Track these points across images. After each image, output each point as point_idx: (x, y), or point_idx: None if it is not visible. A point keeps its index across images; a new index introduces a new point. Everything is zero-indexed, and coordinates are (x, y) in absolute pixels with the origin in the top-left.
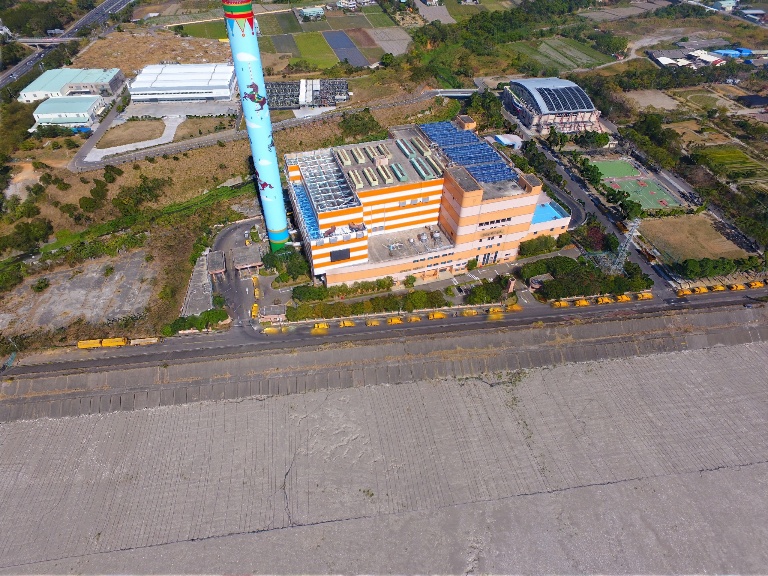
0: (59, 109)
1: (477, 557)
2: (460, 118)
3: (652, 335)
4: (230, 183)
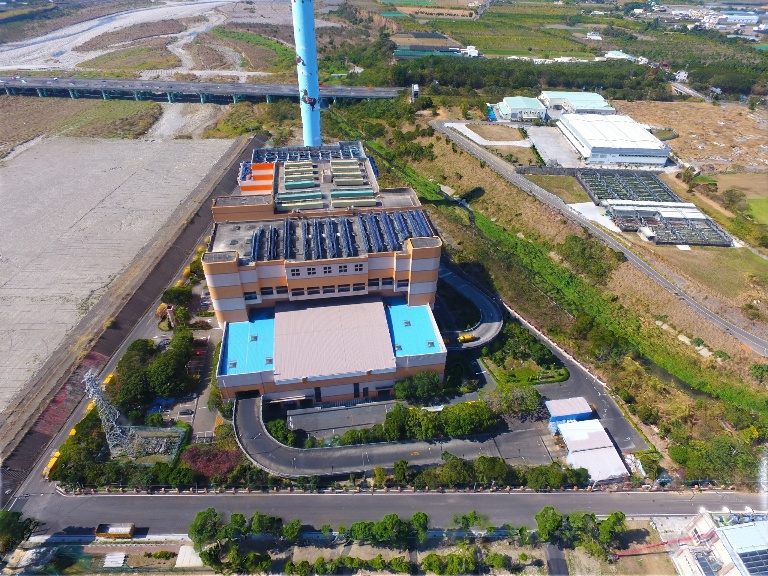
0: (514, 102)
1: (2, 260)
2: (431, 238)
3: (1, 434)
4: (445, 189)
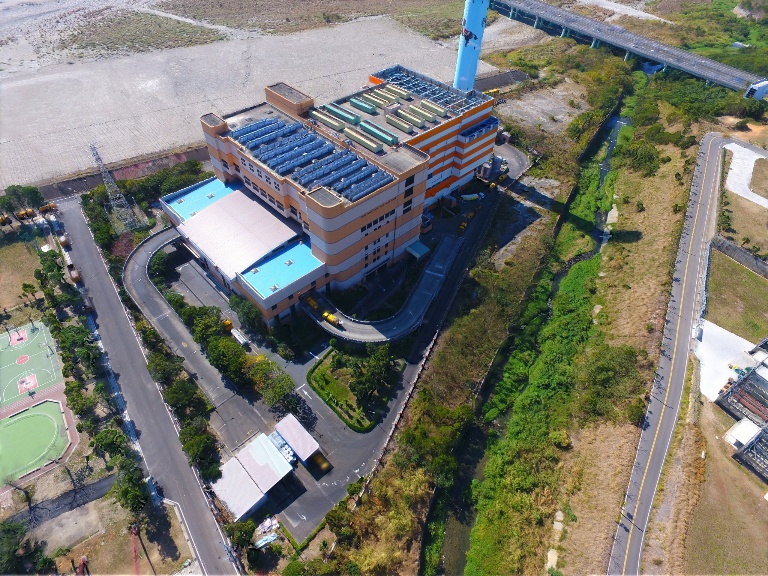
0: None
1: None
2: (336, 198)
3: None
4: (613, 214)
